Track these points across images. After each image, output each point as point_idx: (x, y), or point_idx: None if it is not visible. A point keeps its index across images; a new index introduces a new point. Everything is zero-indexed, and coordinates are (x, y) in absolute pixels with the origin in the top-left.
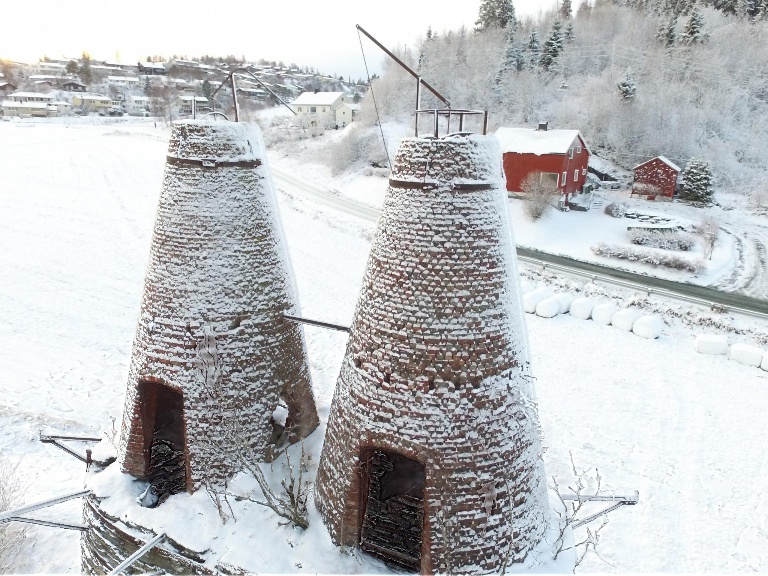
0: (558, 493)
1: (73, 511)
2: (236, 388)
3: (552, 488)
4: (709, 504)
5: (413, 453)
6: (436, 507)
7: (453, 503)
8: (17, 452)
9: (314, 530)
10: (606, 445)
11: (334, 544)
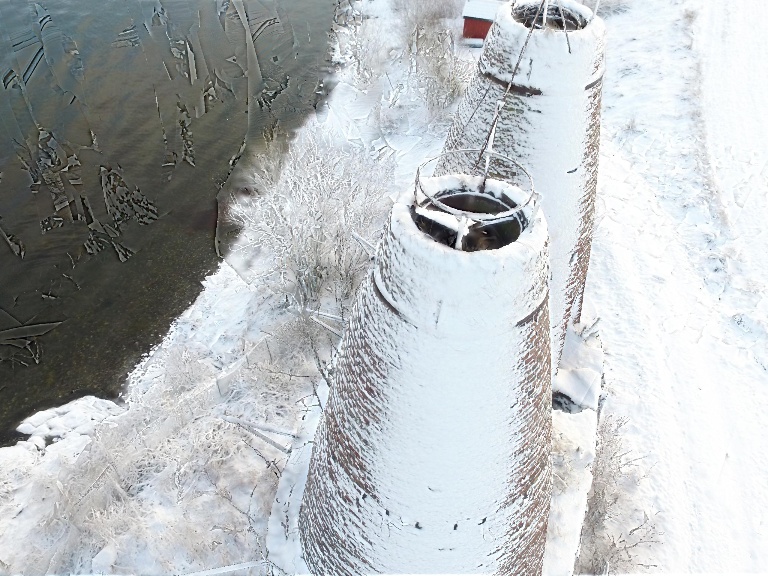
0: None
1: (621, 280)
2: None
3: None
4: None
5: None
6: None
7: None
8: (667, 206)
9: None
10: None
11: None
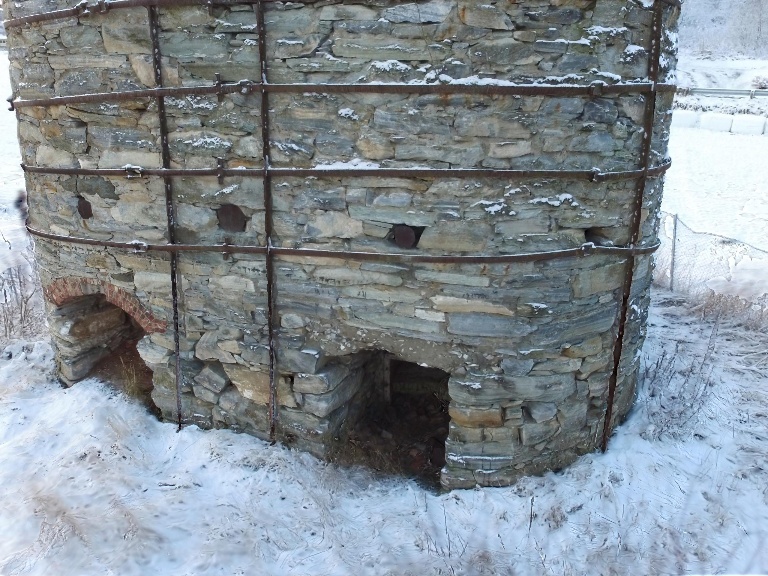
0: None
1: None
2: None
3: None
4: (707, 192)
5: None
6: None
7: None
8: None
9: None
10: None
11: None
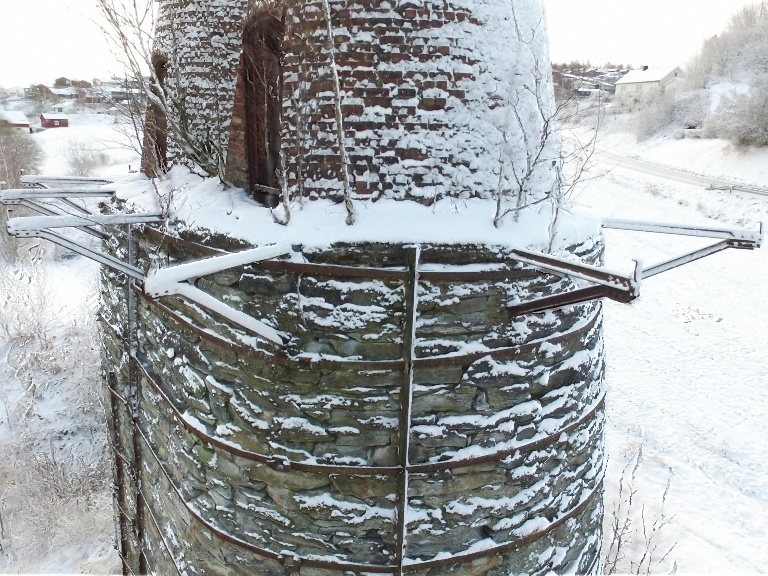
0: (515, 109)
1: None
2: (216, 55)
3: (506, 101)
4: None
5: (274, 6)
6: (291, 83)
7: (313, 77)
8: None
9: (218, 177)
10: None
11: None
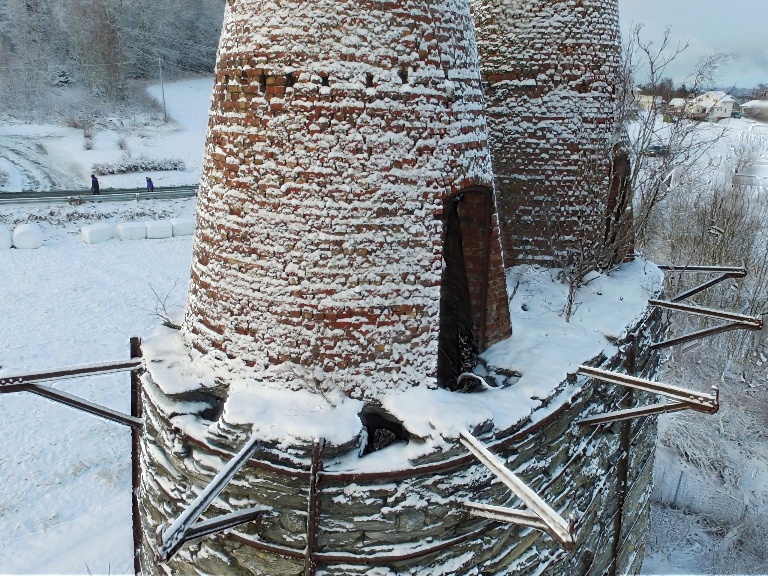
0: None
1: None
2: None
3: None
4: None
5: None
6: None
7: None
8: None
9: (588, 276)
10: (143, 336)
11: (603, 274)
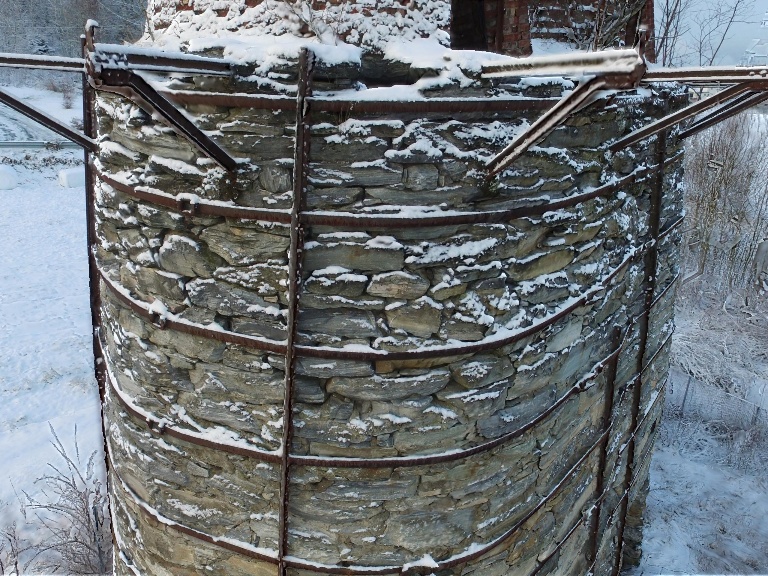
0: None
1: None
2: None
3: None
4: None
5: None
6: None
7: None
8: None
9: None
10: None
11: None
